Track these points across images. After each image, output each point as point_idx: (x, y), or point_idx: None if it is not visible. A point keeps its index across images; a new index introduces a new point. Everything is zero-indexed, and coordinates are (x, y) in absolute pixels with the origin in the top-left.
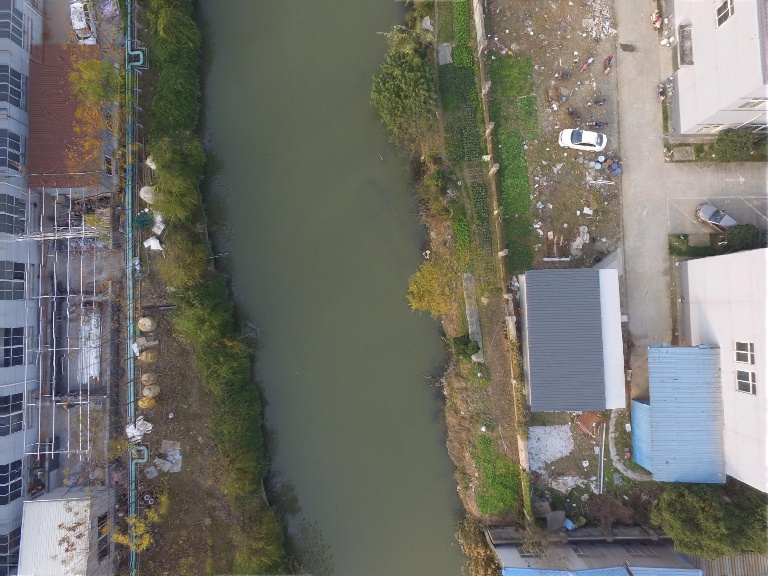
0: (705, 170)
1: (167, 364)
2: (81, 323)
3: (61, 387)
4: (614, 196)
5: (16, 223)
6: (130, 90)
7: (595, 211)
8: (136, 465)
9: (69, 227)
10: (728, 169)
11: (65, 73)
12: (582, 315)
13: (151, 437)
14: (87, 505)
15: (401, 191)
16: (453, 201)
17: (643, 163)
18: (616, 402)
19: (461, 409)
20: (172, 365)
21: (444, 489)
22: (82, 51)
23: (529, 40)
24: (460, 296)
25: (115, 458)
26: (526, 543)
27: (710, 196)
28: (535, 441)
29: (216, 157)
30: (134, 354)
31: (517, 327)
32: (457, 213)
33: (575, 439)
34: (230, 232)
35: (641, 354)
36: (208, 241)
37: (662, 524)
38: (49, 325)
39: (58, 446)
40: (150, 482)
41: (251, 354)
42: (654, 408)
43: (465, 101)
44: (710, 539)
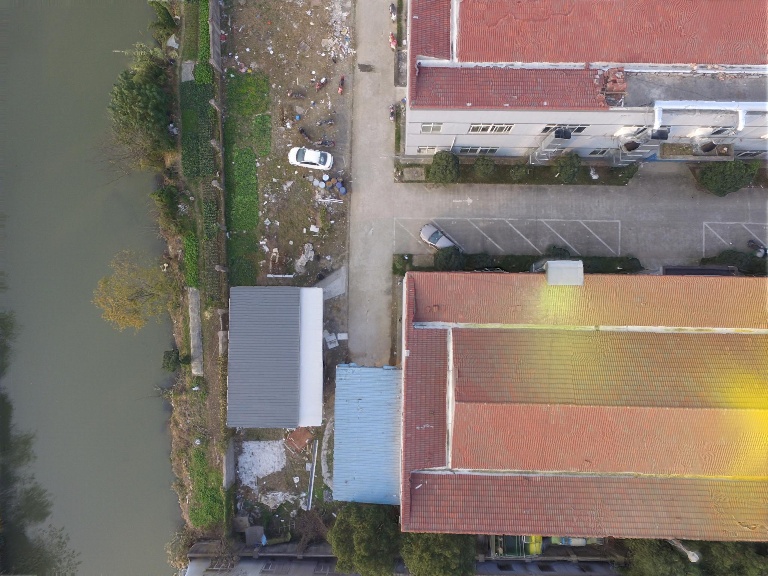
0: (433, 191)
1: None
2: None
3: None
4: (341, 215)
5: None
6: None
7: (321, 229)
8: None
9: None
10: (457, 190)
11: None
12: (281, 332)
13: None
14: None
15: (141, 205)
16: (184, 216)
17: (373, 182)
18: (312, 420)
19: (180, 421)
20: None
21: (167, 500)
22: None
23: (268, 59)
24: (186, 310)
25: None
26: (221, 557)
27: (437, 217)
28: (249, 456)
29: None
30: None
31: None
32: (187, 228)
33: (288, 455)
34: None
35: None
36: None
37: None
38: None
39: None
40: None
41: None
42: (337, 427)
43: (204, 118)
44: (354, 561)
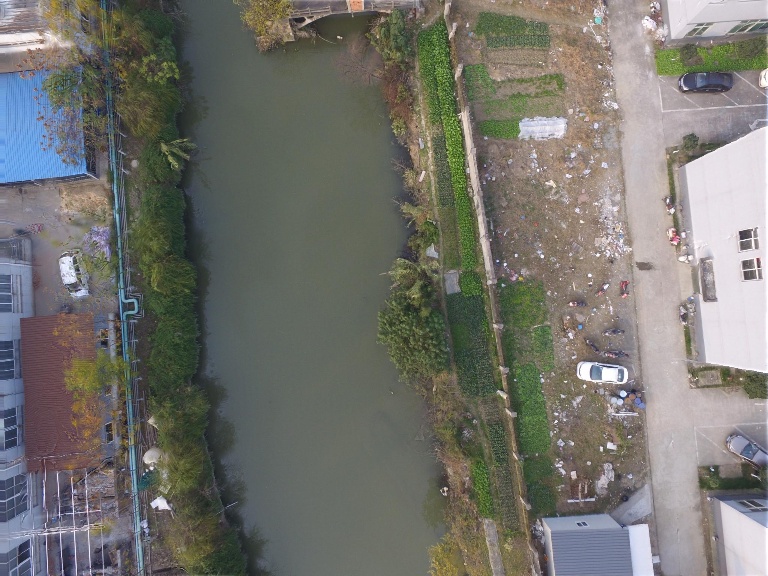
0: (733, 395)
1: None
2: None
3: None
4: (638, 428)
5: (18, 509)
6: (126, 342)
7: (619, 446)
8: None
9: (73, 514)
10: None
11: (58, 324)
12: None
13: None
14: None
15: (414, 427)
16: (469, 442)
17: (667, 391)
18: None
19: None
20: None
21: None
22: (74, 302)
23: (540, 264)
24: (482, 542)
25: None
26: None
27: (740, 423)
28: None
29: (219, 387)
30: None
31: (544, 574)
32: (474, 455)
33: None
34: (239, 480)
35: None
36: (217, 491)
37: None
38: None
39: None
40: None
41: None
42: None
43: (476, 332)
44: None
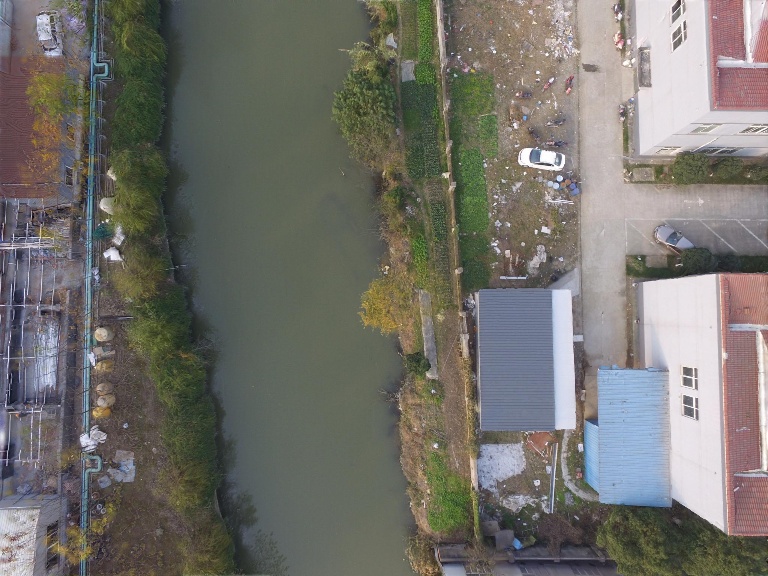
0: (664, 191)
1: (123, 374)
2: (38, 332)
3: (18, 395)
4: (572, 216)
5: None
6: (94, 101)
7: (553, 230)
8: (89, 474)
9: (26, 237)
10: (687, 191)
11: (31, 83)
12: (534, 335)
13: (105, 447)
14: (36, 514)
15: (361, 206)
16: (412, 217)
17: (602, 183)
18: (566, 423)
19: (414, 425)
20: (128, 375)
21: (397, 505)
22: (48, 62)
23: (491, 59)
24: (416, 312)
25: (68, 467)
26: (474, 562)
27: (668, 217)
28: (487, 459)
29: (181, 168)
30: (90, 364)
31: (472, 345)
32: (415, 230)
33: (527, 458)
34: (191, 244)
35: (595, 374)
36: (168, 252)
37: (606, 547)
38: (7, 333)
39: (13, 453)
40: (103, 491)
41: (208, 366)
42: (602, 430)
43: (427, 118)
44: (650, 564)
